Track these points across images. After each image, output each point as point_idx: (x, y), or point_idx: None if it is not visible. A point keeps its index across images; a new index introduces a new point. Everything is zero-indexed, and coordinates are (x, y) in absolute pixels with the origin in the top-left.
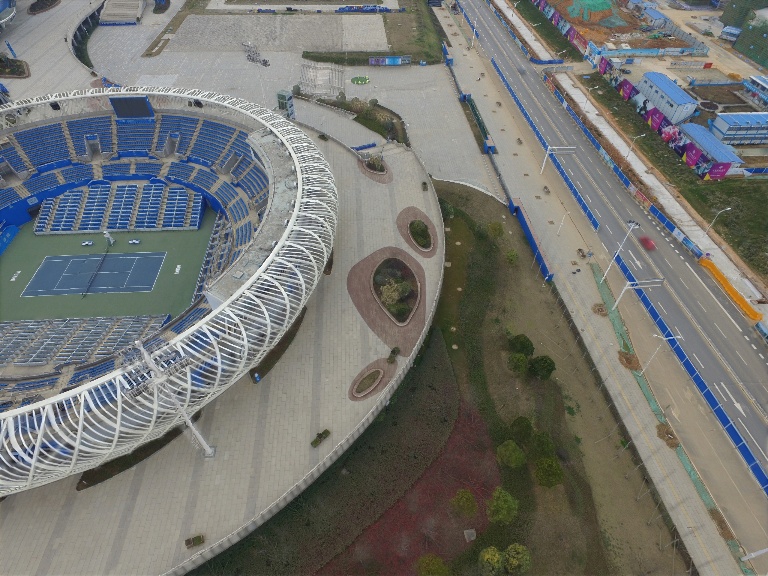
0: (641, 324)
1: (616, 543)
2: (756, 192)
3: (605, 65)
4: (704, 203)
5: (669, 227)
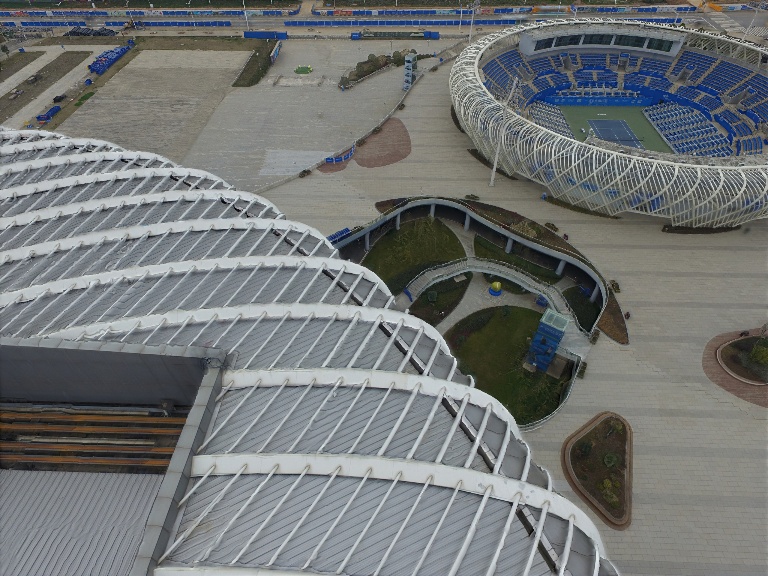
0: None
1: None
2: None
3: None
4: (485, 4)
5: (510, 11)
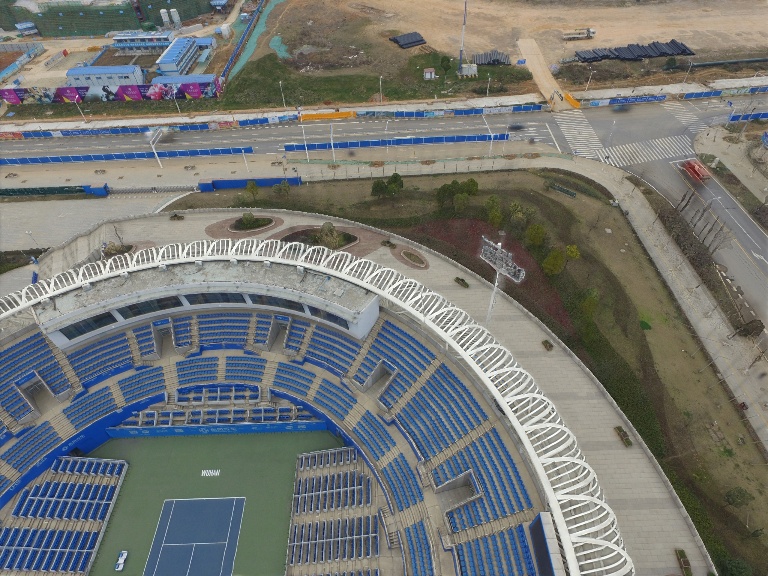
0: (348, 154)
1: (493, 186)
2: (246, 81)
3: (14, 94)
4: (242, 104)
5: (263, 122)
